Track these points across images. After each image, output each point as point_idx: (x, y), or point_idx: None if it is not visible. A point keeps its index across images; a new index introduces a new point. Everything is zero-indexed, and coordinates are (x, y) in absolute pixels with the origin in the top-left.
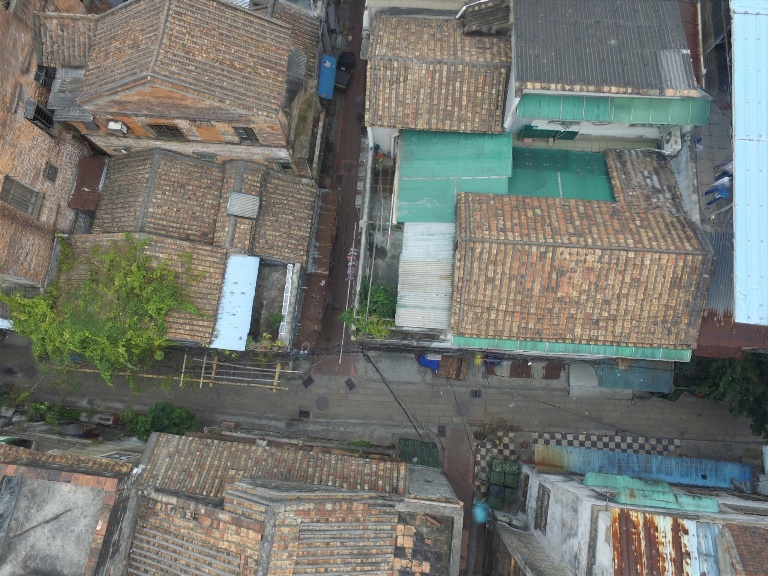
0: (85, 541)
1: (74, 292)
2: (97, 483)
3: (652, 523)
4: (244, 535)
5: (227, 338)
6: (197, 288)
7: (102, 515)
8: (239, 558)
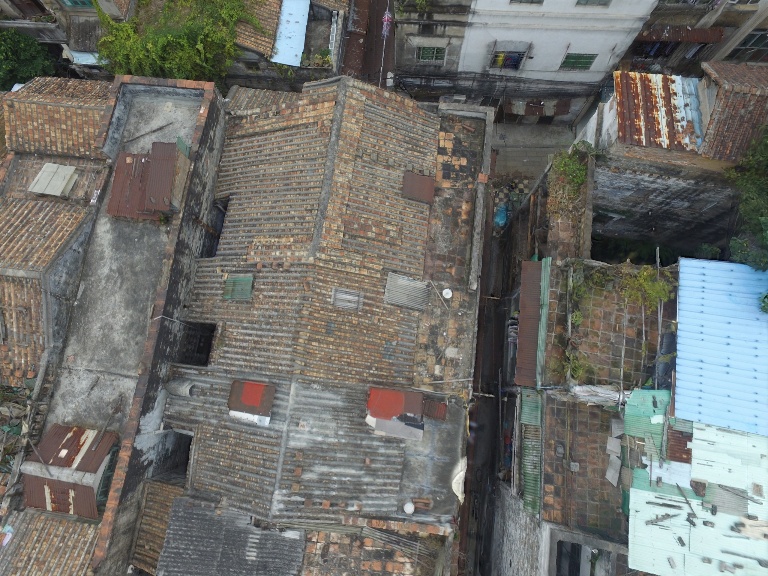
0: (185, 143)
1: (154, 18)
2: (198, 85)
3: (647, 78)
4: (320, 108)
5: (285, 55)
6: (259, 11)
7: (204, 103)
8: (316, 127)
